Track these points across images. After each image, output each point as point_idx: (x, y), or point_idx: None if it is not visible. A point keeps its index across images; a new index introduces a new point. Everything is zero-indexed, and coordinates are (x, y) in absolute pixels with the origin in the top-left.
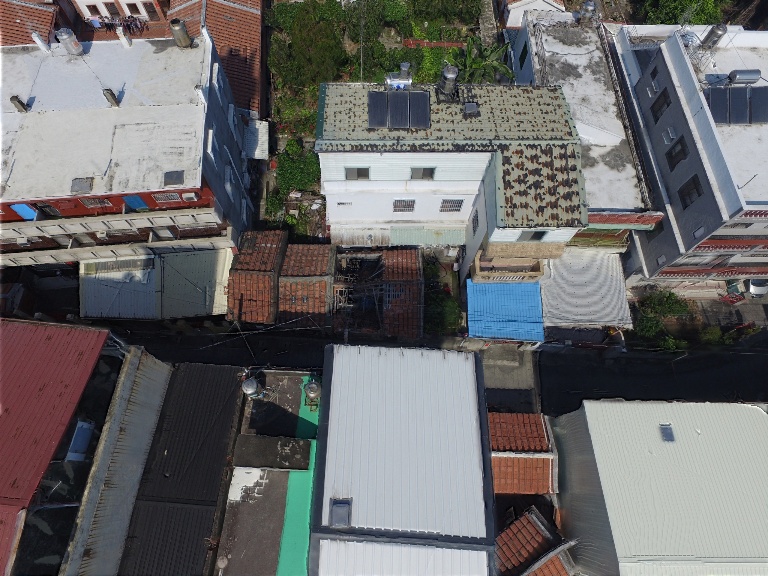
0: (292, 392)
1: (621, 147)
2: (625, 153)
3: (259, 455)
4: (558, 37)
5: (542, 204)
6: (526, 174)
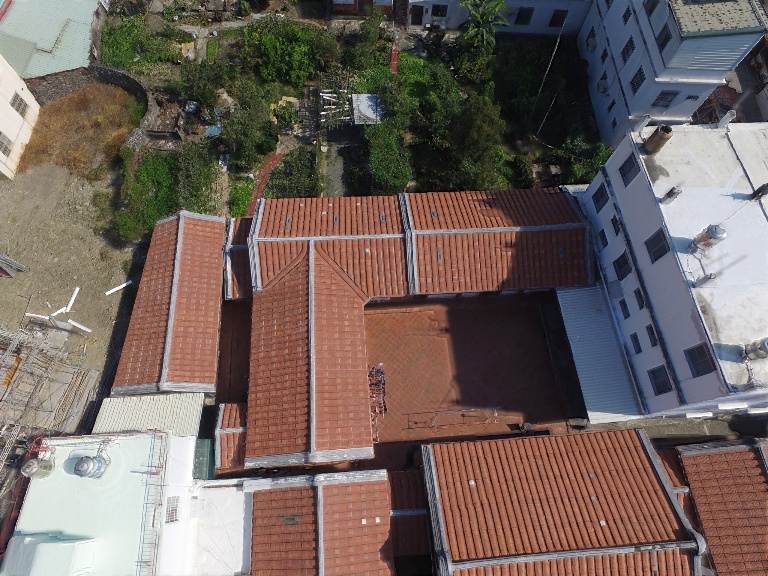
0: None
1: None
2: None
3: None
4: None
5: None
6: None
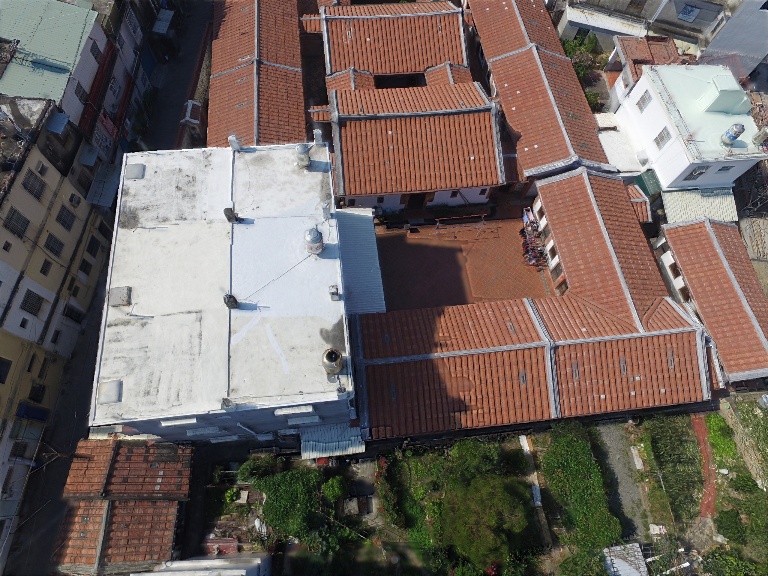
0: None
1: None
2: None
3: None
4: None
5: None
6: None
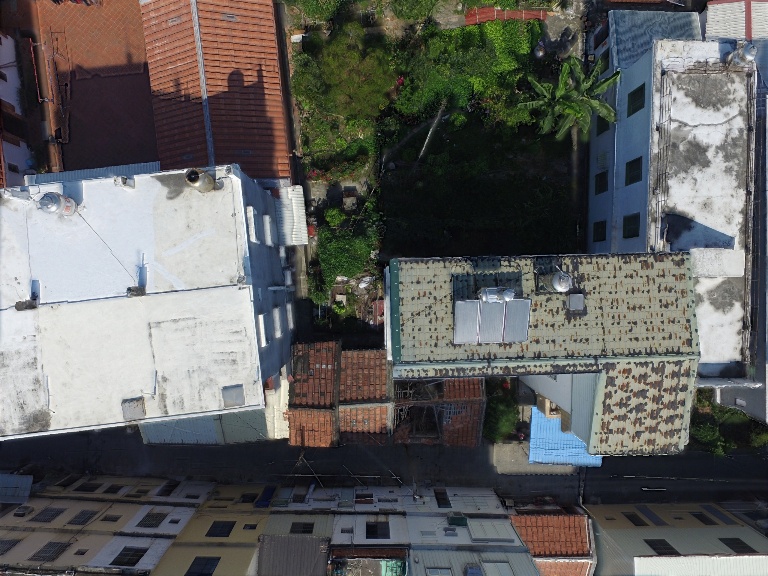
0: (373, 568)
1: (735, 278)
2: (737, 287)
3: None
4: (691, 92)
5: (640, 429)
6: (630, 396)
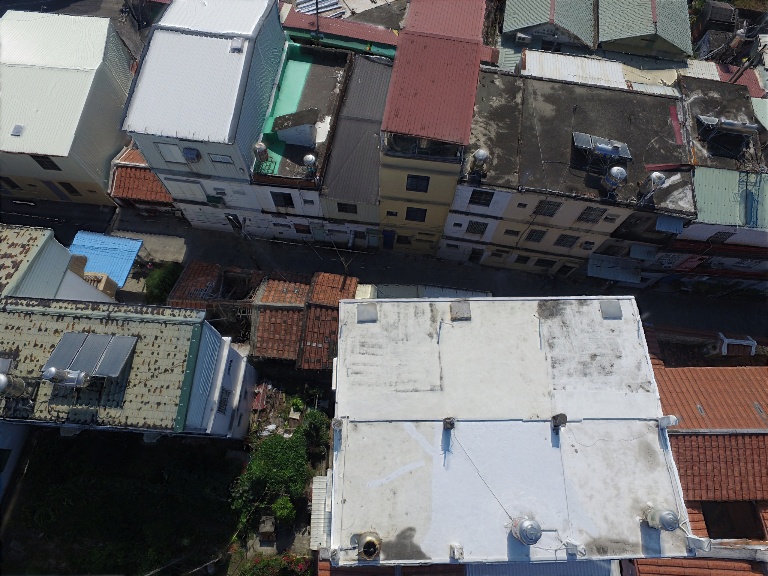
0: (285, 171)
1: None
2: None
3: (302, 116)
4: None
5: None
6: None
